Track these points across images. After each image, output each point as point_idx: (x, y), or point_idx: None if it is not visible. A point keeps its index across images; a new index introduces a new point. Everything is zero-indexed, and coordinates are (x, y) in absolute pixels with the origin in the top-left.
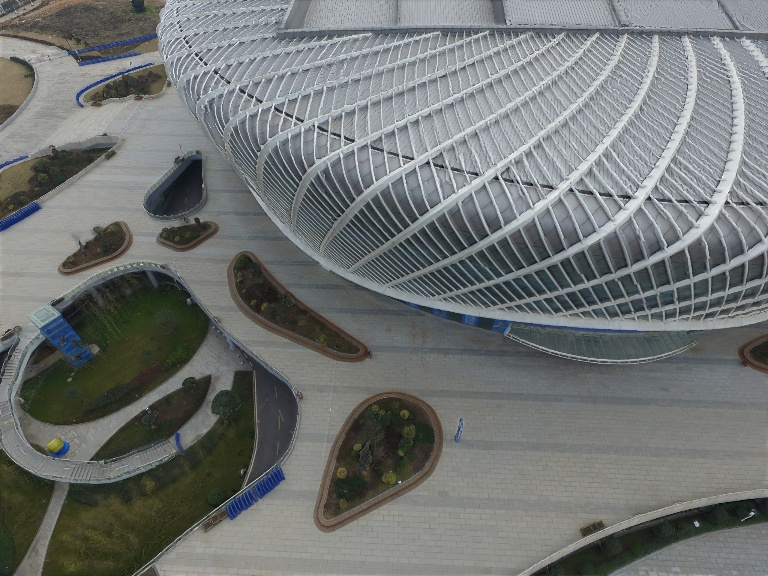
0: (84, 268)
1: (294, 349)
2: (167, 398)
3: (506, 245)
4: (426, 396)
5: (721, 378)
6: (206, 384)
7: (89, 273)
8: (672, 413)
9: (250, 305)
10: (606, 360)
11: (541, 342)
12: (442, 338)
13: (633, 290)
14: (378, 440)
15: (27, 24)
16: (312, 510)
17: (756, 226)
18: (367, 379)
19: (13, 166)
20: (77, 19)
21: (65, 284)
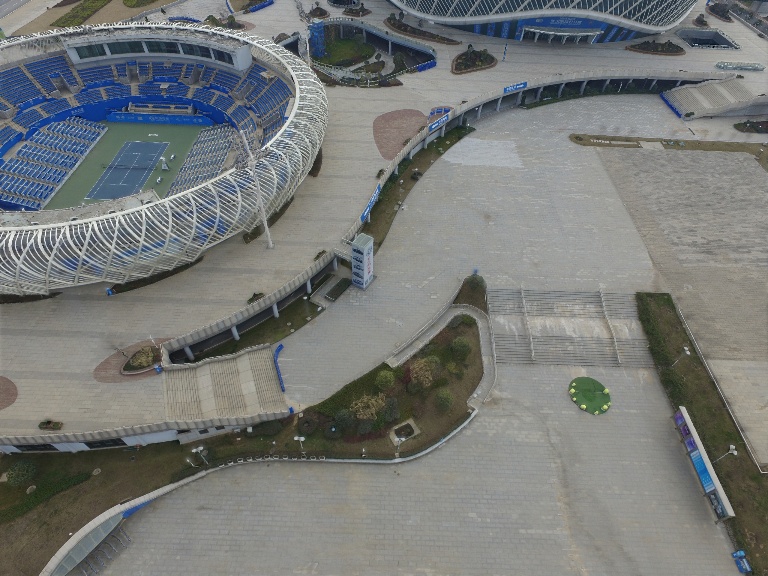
0: None
1: (426, 42)
2: None
3: None
4: None
5: (615, 52)
6: (383, 62)
7: None
8: (593, 58)
9: (401, 29)
10: (565, 34)
11: None
12: (492, 41)
13: None
14: None
15: None
16: (450, 71)
17: None
18: None
19: None
20: None
21: None
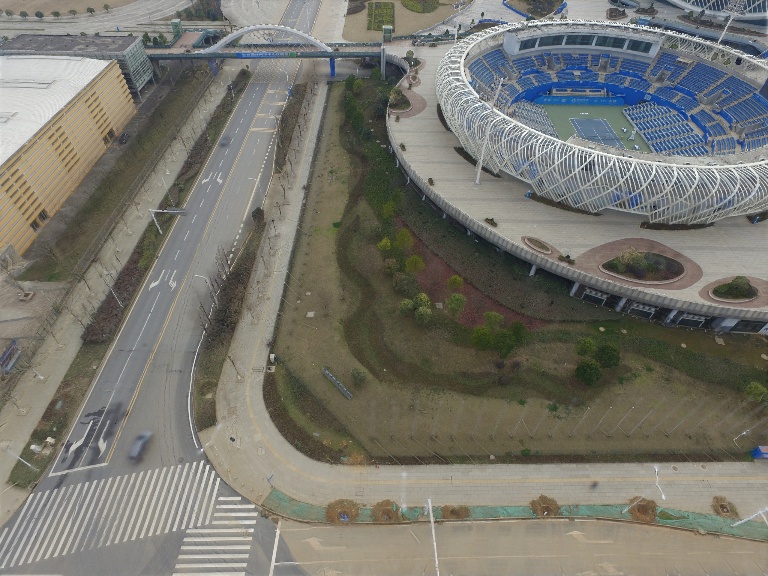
0: (619, 18)
1: None
2: None
3: None
4: None
5: None
6: None
7: (623, 20)
8: None
9: (706, 25)
10: None
11: None
12: None
13: None
14: None
15: None
16: None
17: None
18: None
19: (508, 1)
20: None
21: None
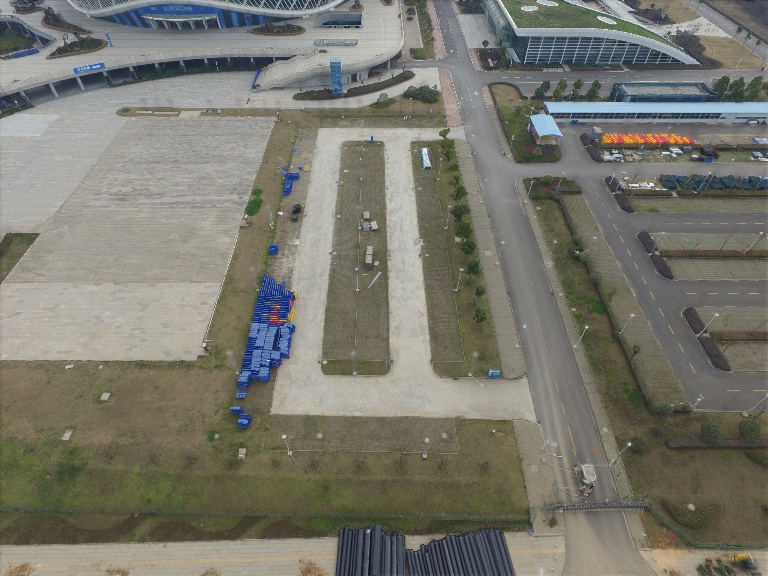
0: None
1: None
2: None
3: None
4: None
5: (234, 35)
6: None
7: None
8: None
9: (47, 23)
10: (174, 19)
11: None
12: None
13: None
14: (77, 42)
15: None
16: None
17: None
18: None
19: None
20: None
21: None
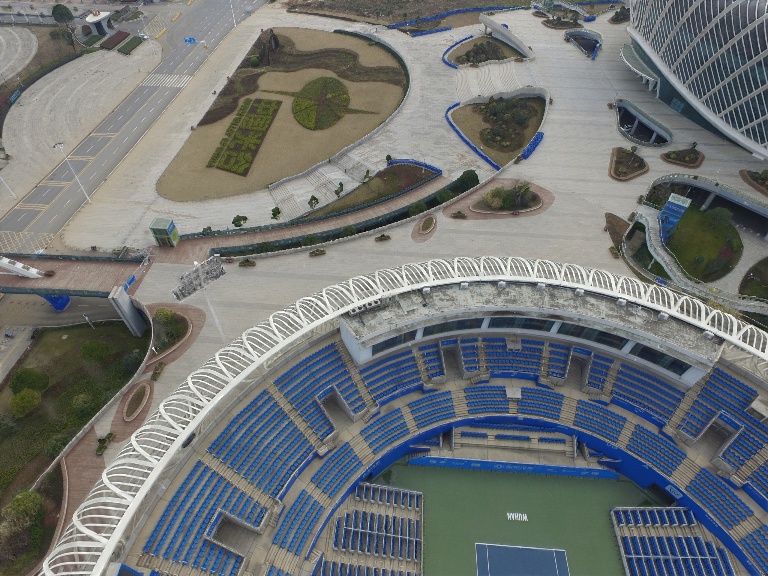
0: (632, 177)
1: None
2: (756, 269)
3: None
4: None
5: None
6: None
7: (639, 181)
8: None
9: None
10: None
11: None
12: None
13: None
14: None
15: (313, 4)
16: None
17: None
18: None
19: (456, 110)
20: (358, 0)
21: (629, 188)
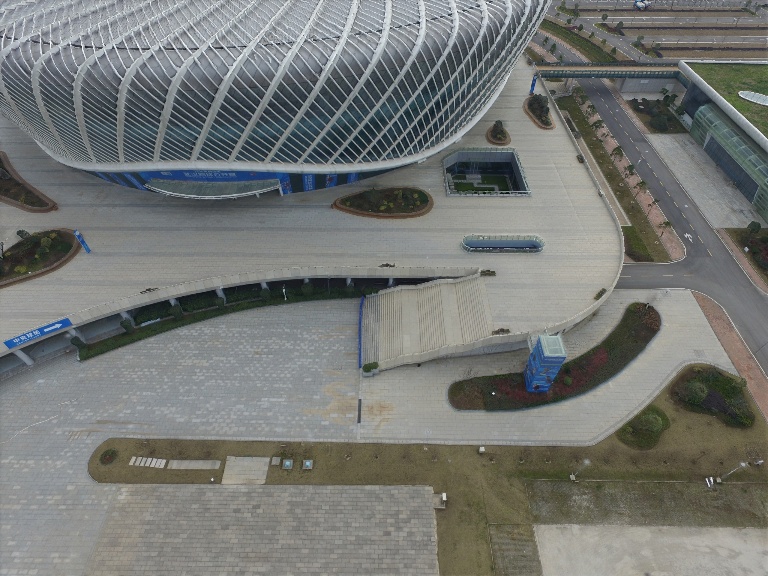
0: None
1: (1, 207)
2: None
3: (45, 87)
4: (83, 230)
5: (309, 215)
6: None
7: None
8: (256, 234)
9: None
10: (204, 196)
11: (165, 188)
12: (118, 198)
13: (152, 122)
14: (24, 250)
15: None
16: None
17: (171, 60)
18: (45, 222)
19: None
20: None
21: None
